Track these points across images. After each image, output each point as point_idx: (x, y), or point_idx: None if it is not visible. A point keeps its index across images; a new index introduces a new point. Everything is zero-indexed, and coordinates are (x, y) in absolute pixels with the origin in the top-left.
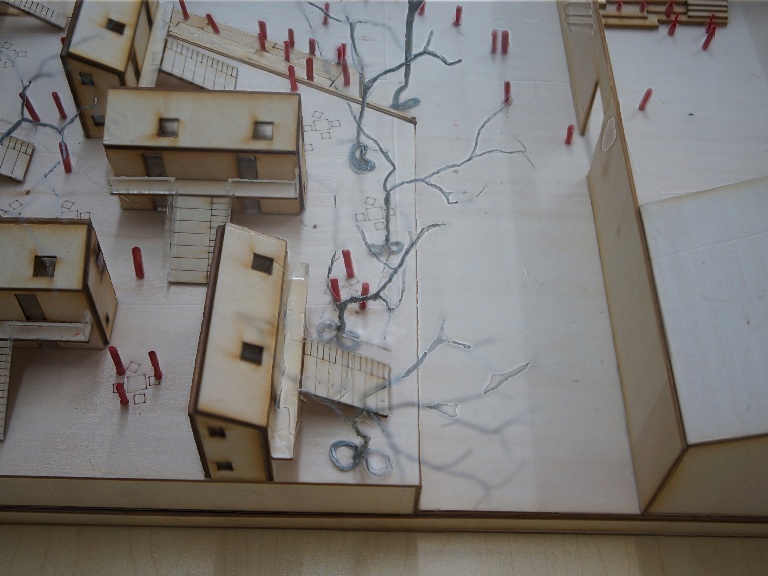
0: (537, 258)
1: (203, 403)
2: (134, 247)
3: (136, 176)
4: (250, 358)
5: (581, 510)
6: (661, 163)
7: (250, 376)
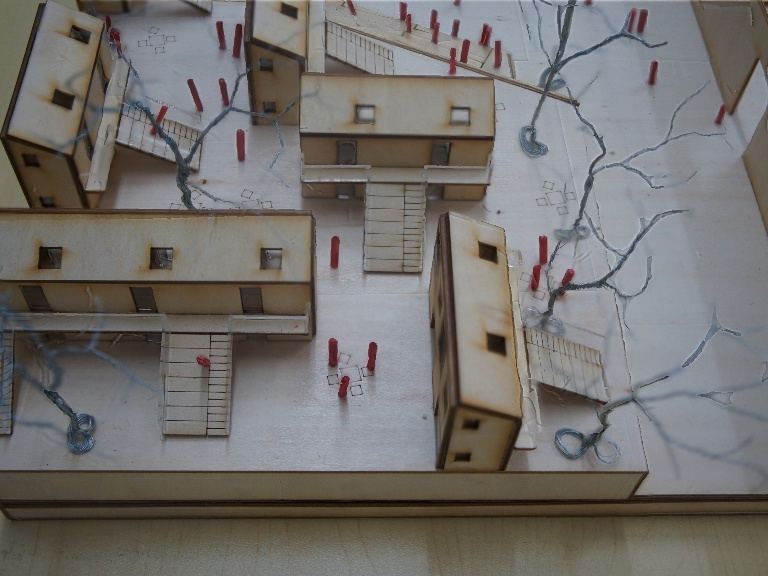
0: (707, 240)
1: (466, 396)
2: (333, 237)
3: (326, 164)
4: (496, 349)
5: None
6: None
7: (499, 367)
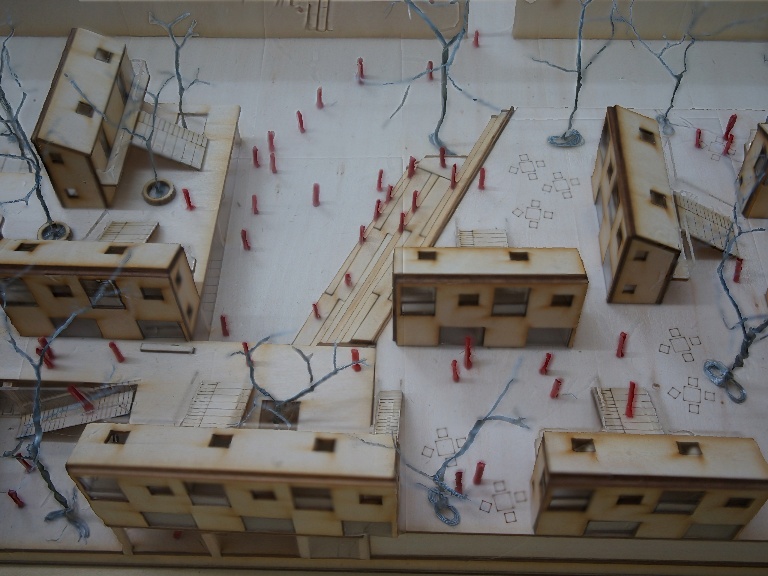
0: (606, 73)
1: None
2: (739, 261)
3: None
4: None
5: None
6: None
7: None
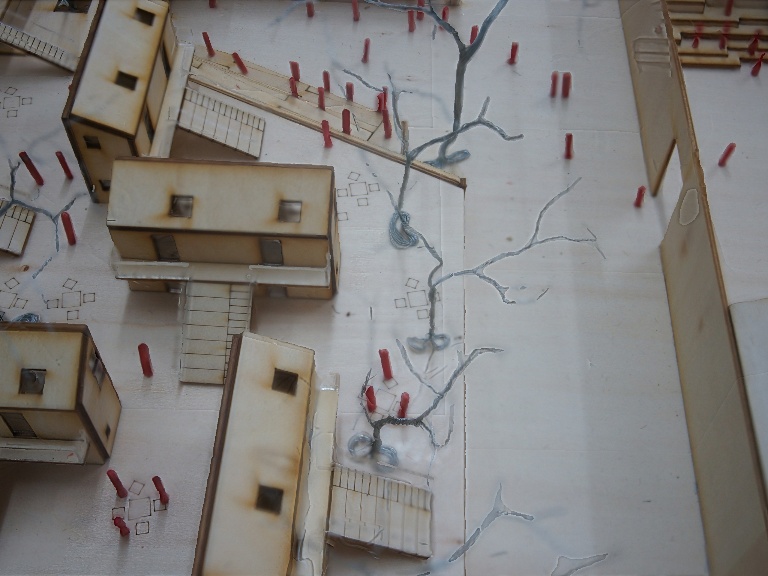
0: (602, 347)
1: (209, 570)
2: (140, 344)
3: (145, 258)
4: (267, 506)
5: None
6: (745, 231)
7: (267, 529)
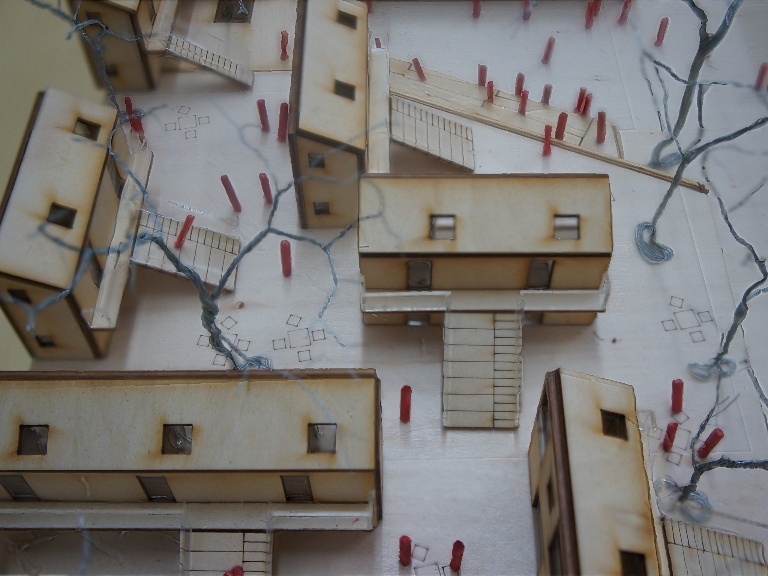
0: None
1: None
2: (403, 386)
3: (393, 288)
4: (634, 575)
5: None
6: None
7: None
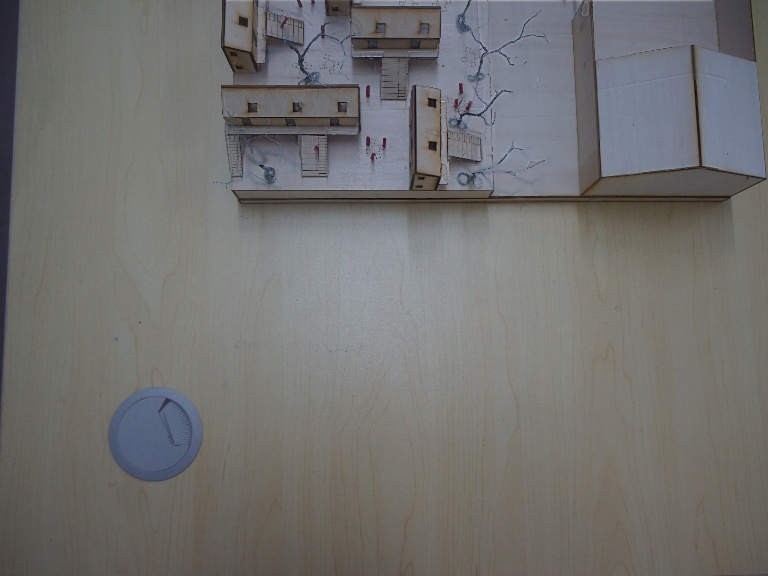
0: (544, 71)
1: (419, 170)
2: (367, 86)
3: (363, 48)
4: (432, 148)
5: (556, 195)
6: (611, 10)
7: (433, 156)
